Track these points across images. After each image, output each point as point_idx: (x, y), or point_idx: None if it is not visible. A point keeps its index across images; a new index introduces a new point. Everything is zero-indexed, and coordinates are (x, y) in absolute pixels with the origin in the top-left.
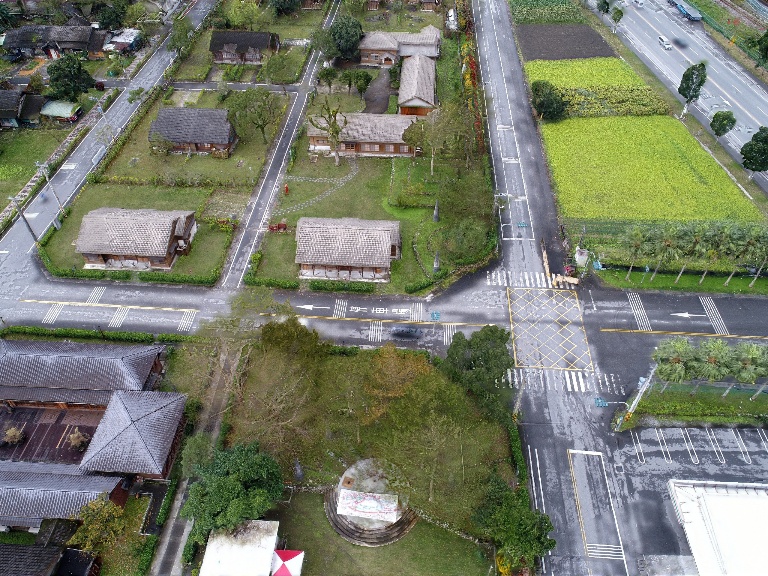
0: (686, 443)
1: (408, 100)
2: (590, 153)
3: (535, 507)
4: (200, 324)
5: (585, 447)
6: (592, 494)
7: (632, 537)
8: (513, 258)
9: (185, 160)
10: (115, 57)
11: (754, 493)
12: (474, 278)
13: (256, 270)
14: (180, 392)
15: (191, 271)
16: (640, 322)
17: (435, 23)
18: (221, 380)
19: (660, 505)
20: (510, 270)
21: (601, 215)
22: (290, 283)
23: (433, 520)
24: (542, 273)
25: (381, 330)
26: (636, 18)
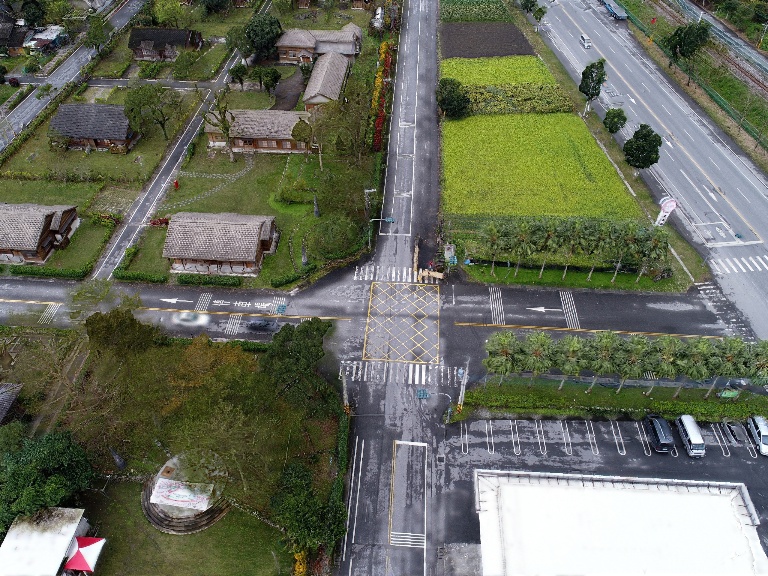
0: (512, 434)
1: (312, 97)
2: (485, 150)
3: (349, 496)
4: (61, 317)
5: (412, 438)
6: (408, 484)
7: (438, 526)
8: (385, 253)
9: (82, 156)
10: (36, 54)
11: (555, 483)
12: (342, 273)
13: (128, 264)
14: (24, 383)
15: (64, 265)
16: (495, 316)
17: (362, 21)
18: (69, 372)
19: (472, 495)
20: (379, 265)
21: (482, 211)
22: (158, 277)
23: (244, 509)
24: (410, 268)
25: (239, 323)
26: (562, 17)
